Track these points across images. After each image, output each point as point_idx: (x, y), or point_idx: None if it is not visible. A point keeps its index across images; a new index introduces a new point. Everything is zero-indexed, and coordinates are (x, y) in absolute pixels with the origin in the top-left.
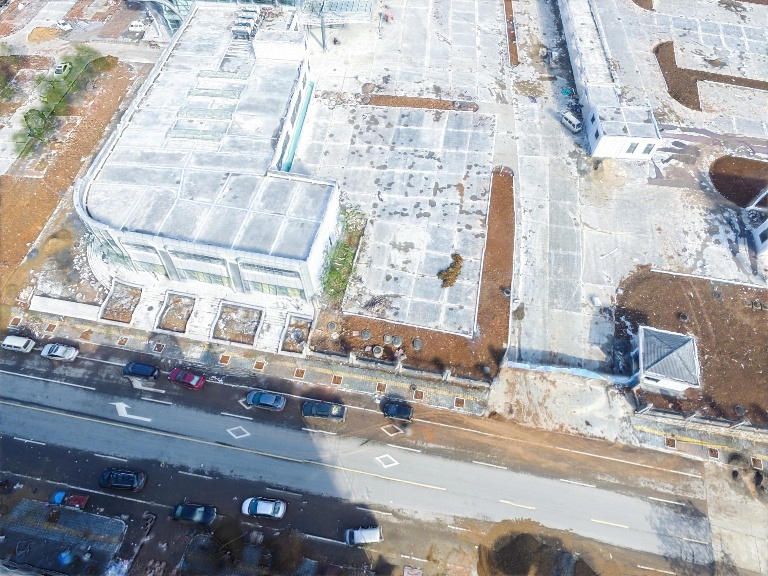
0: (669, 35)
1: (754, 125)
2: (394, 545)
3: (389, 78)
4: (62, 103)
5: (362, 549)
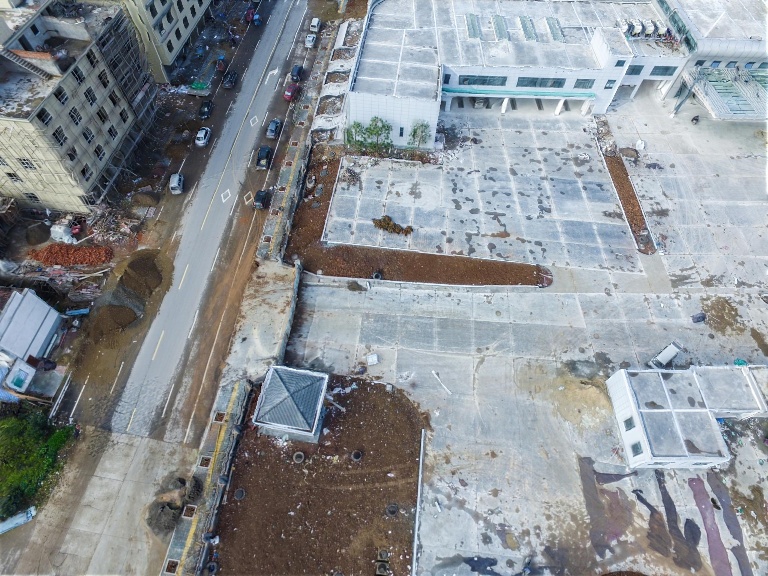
0: None
1: None
2: (170, 202)
3: (658, 168)
4: None
5: (168, 181)
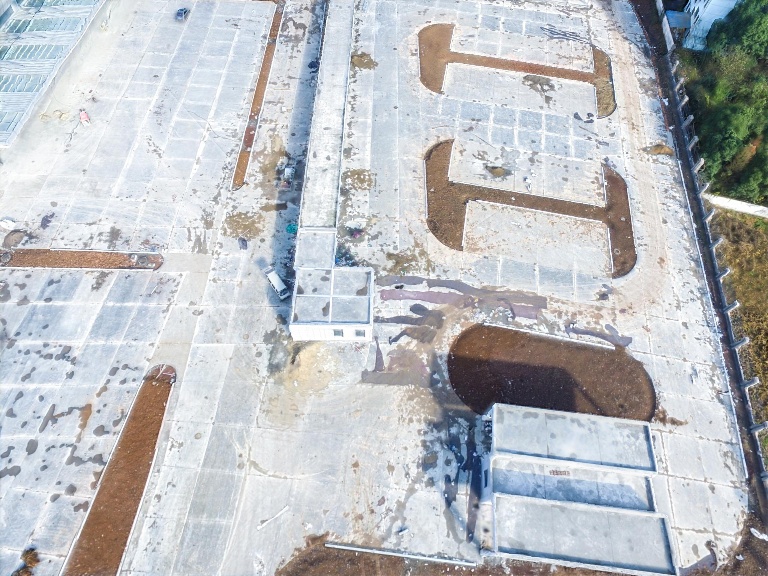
0: (451, 130)
1: (524, 270)
2: None
3: (51, 219)
4: None
5: None
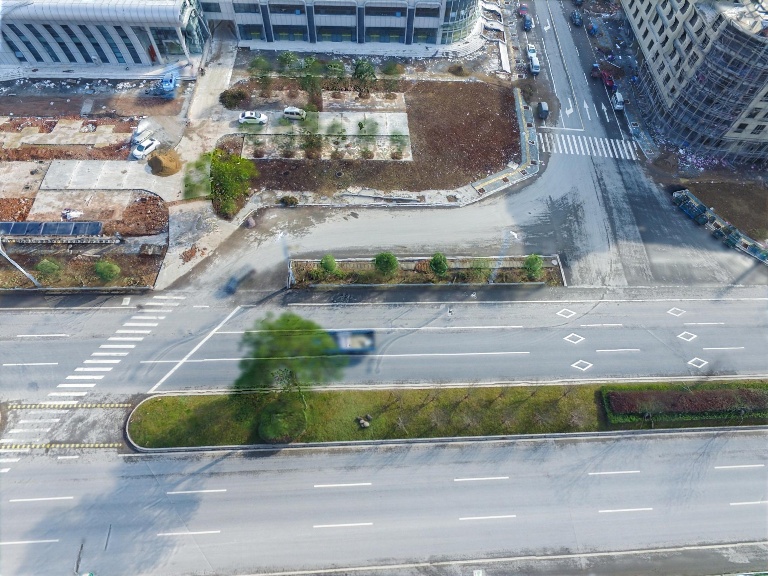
0: None
1: None
2: None
3: None
4: (303, 109)
5: None
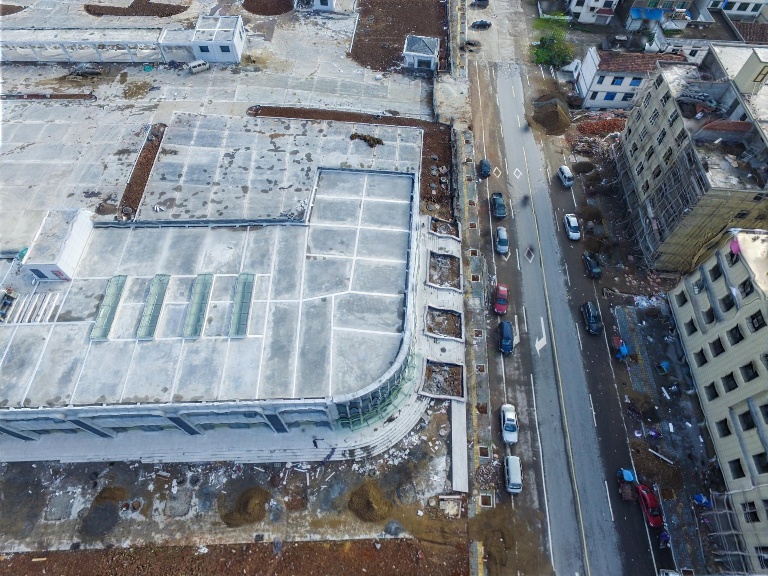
0: (74, 5)
1: None
2: None
3: (90, 192)
4: None
5: None
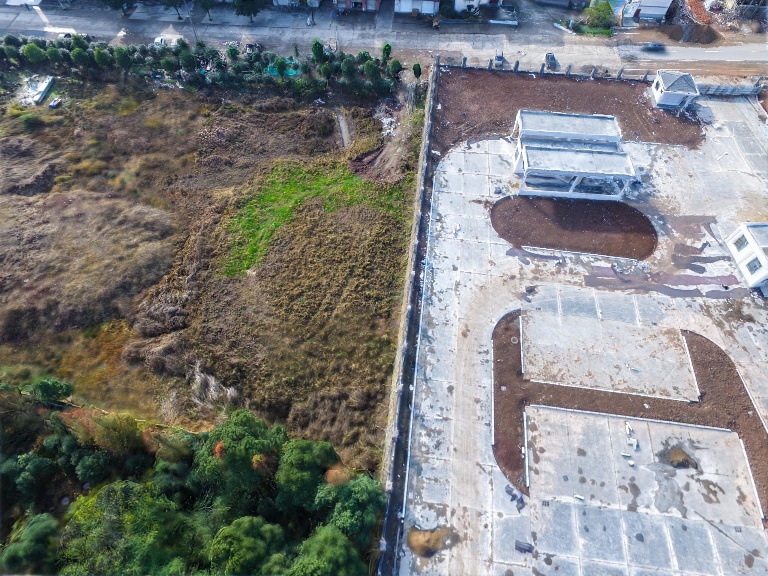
0: None
1: (612, 312)
2: None
3: None
4: None
5: None
